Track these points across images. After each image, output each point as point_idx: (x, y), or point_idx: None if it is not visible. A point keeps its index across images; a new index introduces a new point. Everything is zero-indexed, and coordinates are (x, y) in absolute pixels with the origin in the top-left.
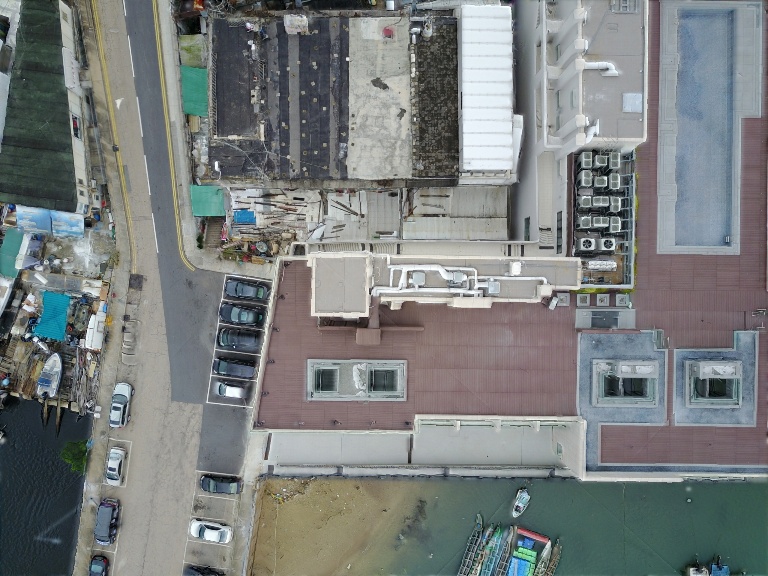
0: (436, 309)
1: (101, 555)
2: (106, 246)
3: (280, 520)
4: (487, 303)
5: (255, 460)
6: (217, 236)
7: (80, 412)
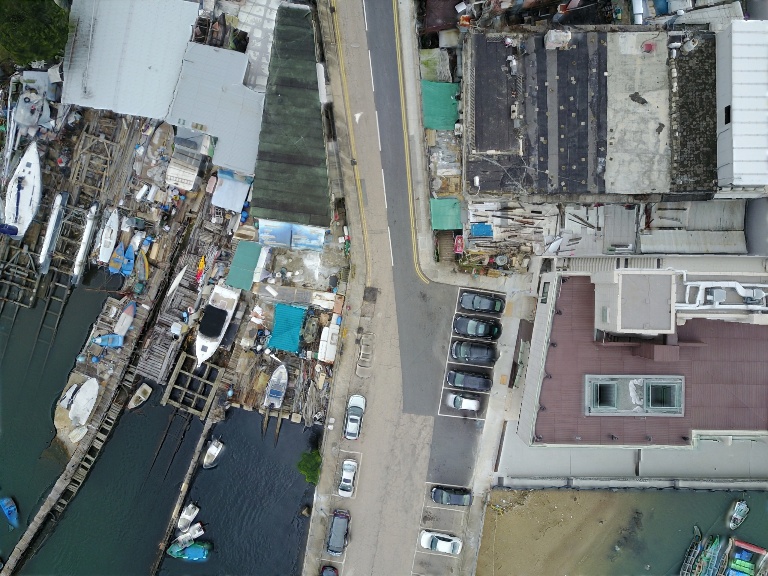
0: (713, 325)
1: (330, 565)
2: (335, 259)
3: (499, 531)
4: None
5: (485, 472)
6: (450, 249)
7: (307, 423)
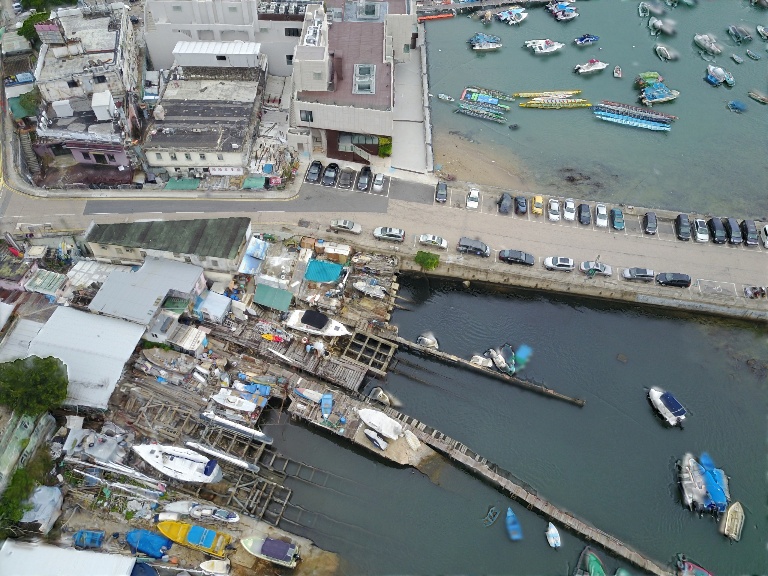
0: None
1: None
2: (276, 249)
3: None
4: (325, 22)
5: (425, 178)
6: None
7: (397, 270)
